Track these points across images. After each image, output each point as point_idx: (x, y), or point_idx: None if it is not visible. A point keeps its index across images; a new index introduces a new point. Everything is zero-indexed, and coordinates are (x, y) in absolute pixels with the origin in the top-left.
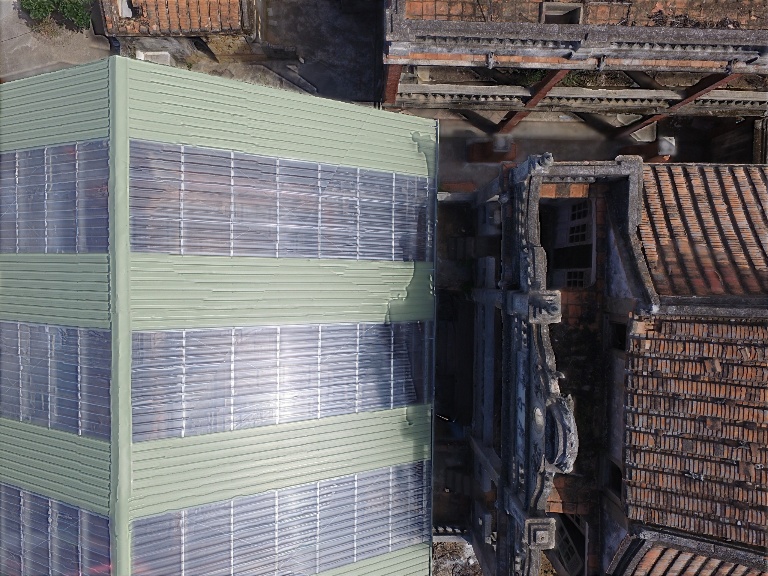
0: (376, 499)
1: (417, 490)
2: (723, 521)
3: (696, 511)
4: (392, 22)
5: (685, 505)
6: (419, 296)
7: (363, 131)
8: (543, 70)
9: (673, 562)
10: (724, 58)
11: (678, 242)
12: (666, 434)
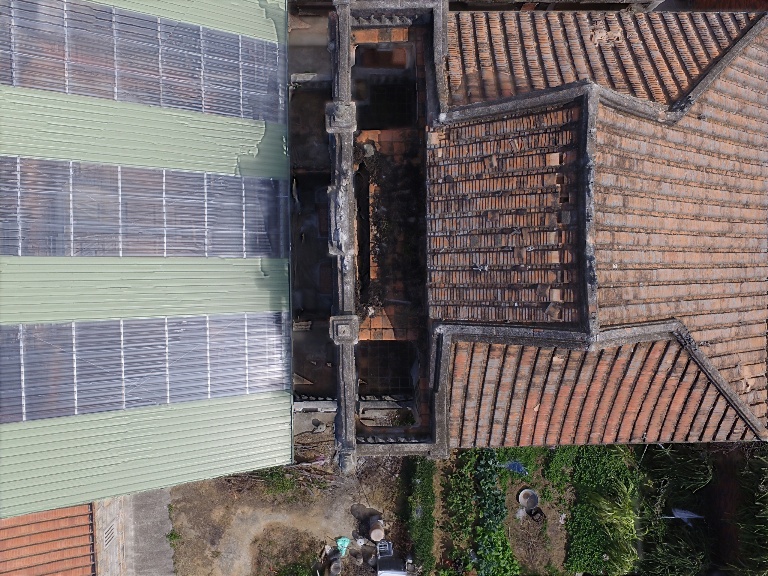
0: (230, 342)
1: (276, 340)
2: (504, 305)
3: (483, 301)
4: None
5: (473, 296)
6: (271, 155)
7: None
8: None
9: (486, 370)
10: None
11: (482, 71)
12: (458, 234)
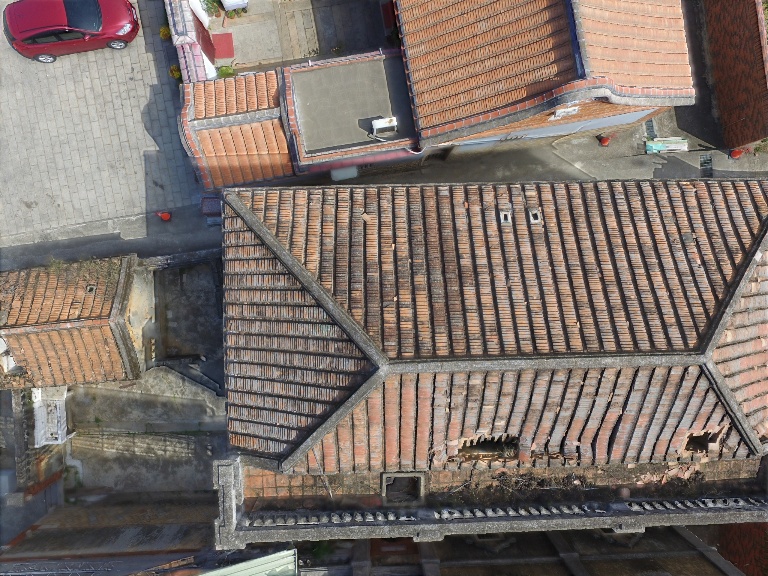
0: None
1: None
2: None
3: None
4: (220, 535)
5: None
6: None
7: None
8: None
9: None
10: None
11: None
12: None
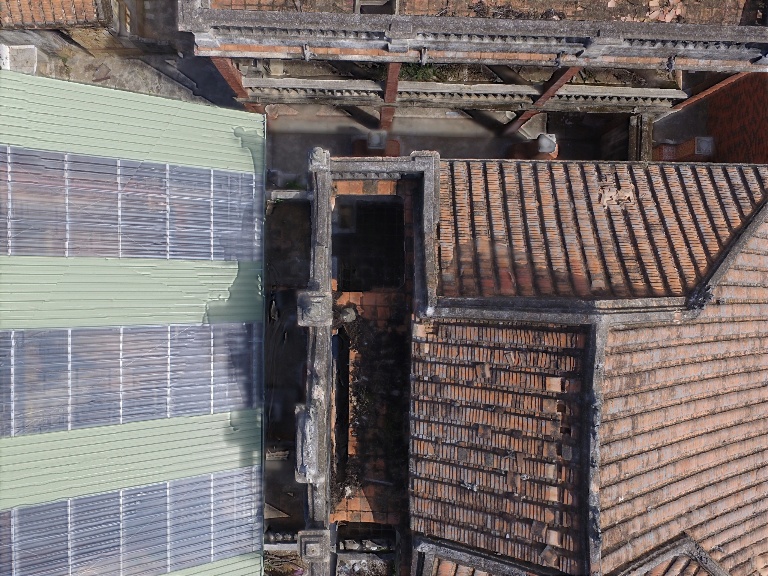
0: (194, 507)
1: (245, 498)
2: (494, 534)
3: (471, 523)
4: (183, 11)
5: (460, 517)
6: (245, 297)
7: (173, 125)
8: None
9: (473, 575)
10: (550, 51)
11: (477, 241)
12: (445, 442)
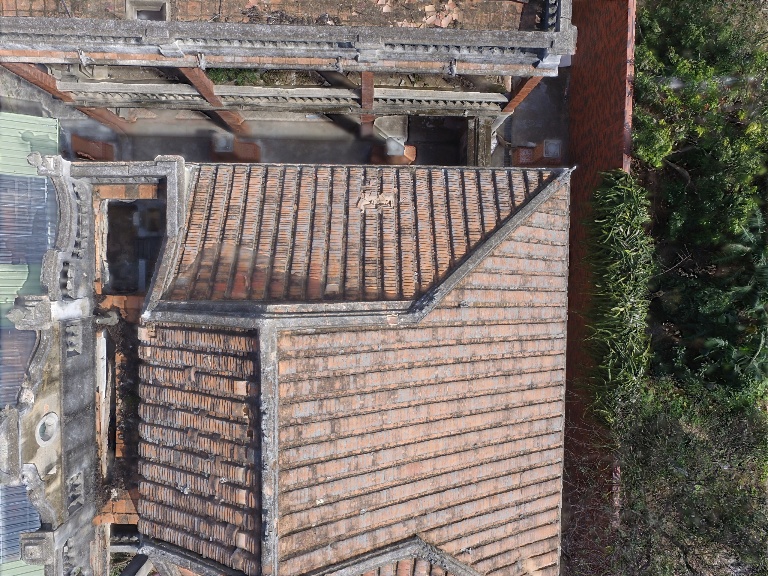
0: None
1: None
2: (201, 537)
3: (184, 526)
4: None
5: (175, 519)
6: None
7: None
8: (215, 68)
9: None
10: (327, 55)
11: (223, 245)
12: (166, 445)
